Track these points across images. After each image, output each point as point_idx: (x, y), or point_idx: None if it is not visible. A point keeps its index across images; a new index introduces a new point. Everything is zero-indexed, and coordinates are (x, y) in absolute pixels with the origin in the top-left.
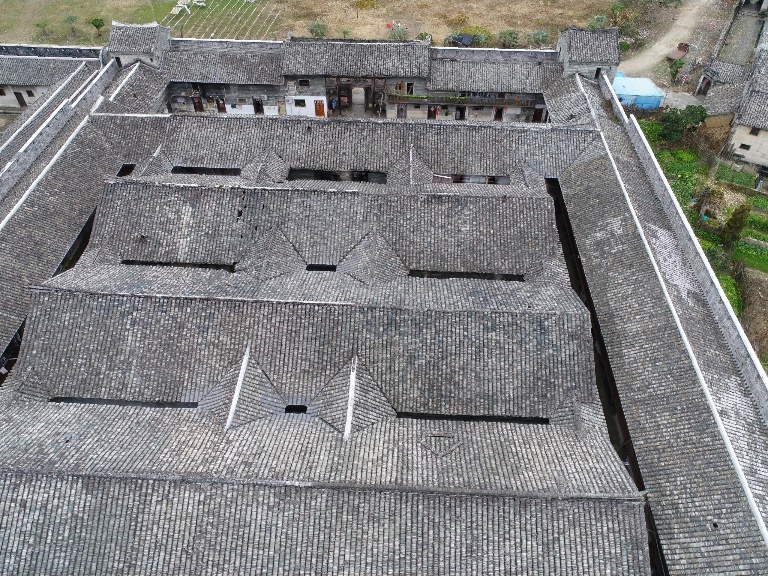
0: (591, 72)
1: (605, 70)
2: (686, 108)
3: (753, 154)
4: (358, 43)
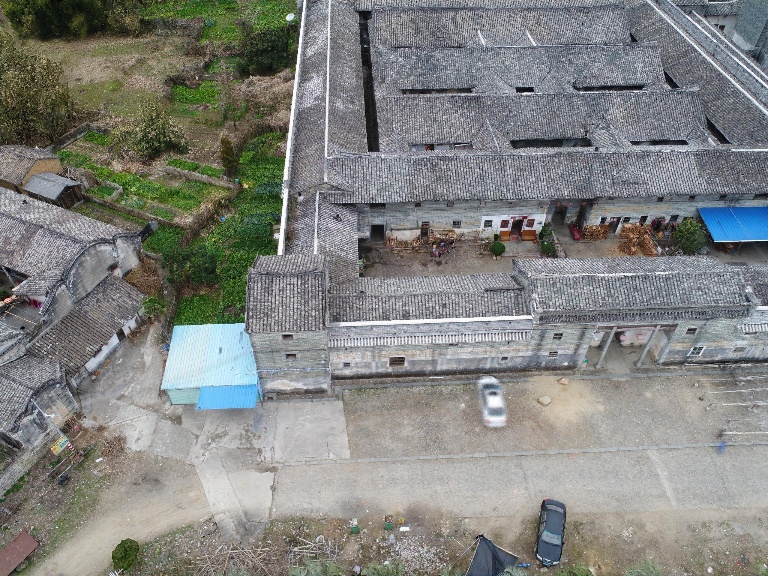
0: None
1: None
2: (187, 253)
3: None
4: (634, 273)
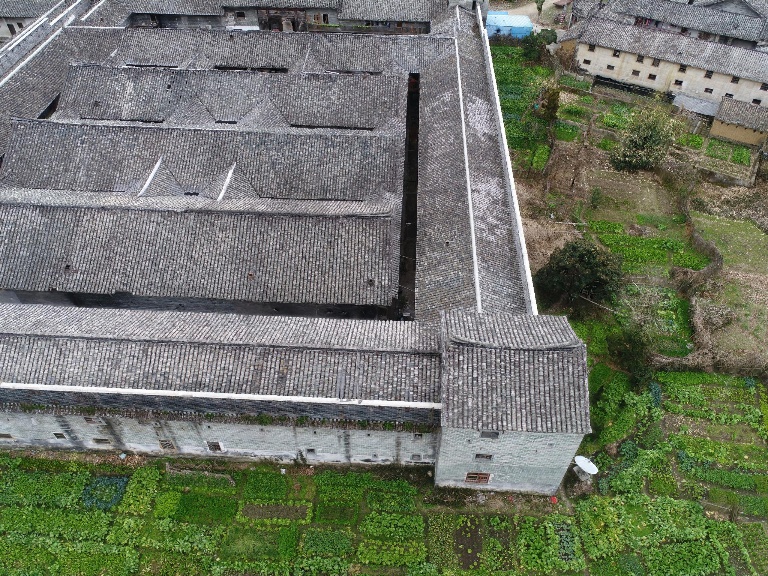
0: (469, 4)
1: (478, 2)
2: (541, 31)
3: (593, 68)
4: None
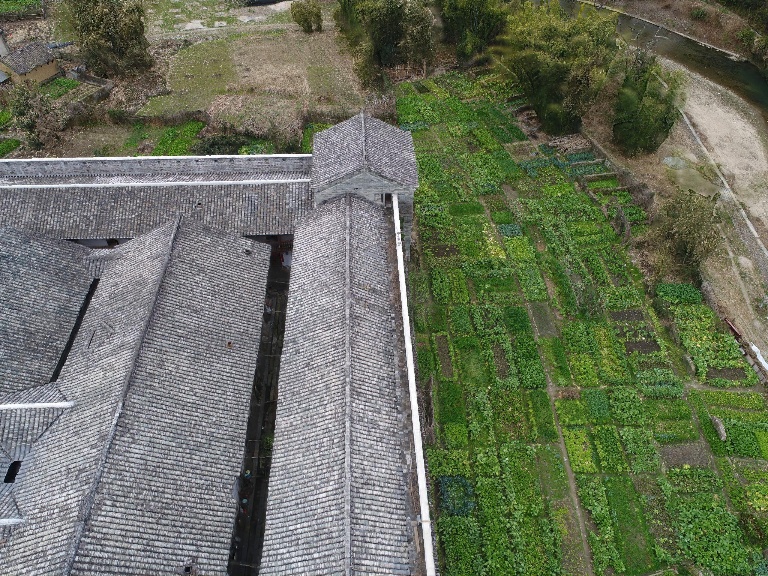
0: None
1: None
2: None
3: None
4: None
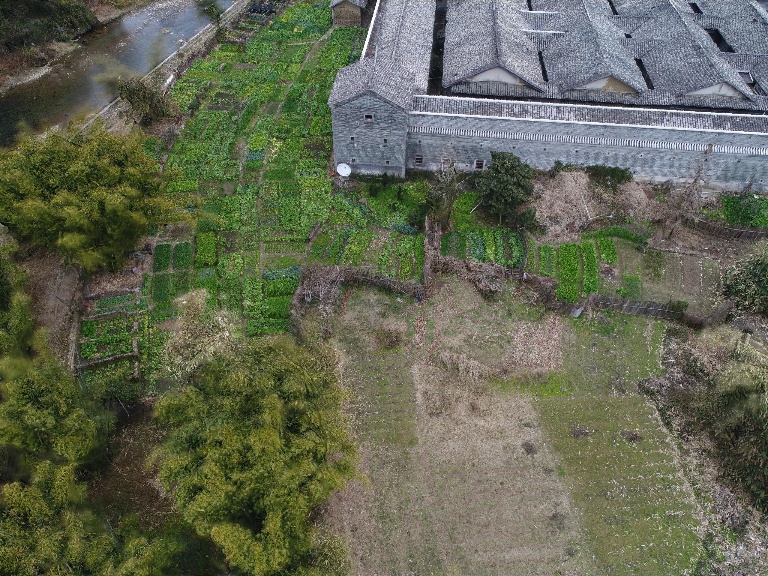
0: None
1: None
2: None
3: None
4: None
